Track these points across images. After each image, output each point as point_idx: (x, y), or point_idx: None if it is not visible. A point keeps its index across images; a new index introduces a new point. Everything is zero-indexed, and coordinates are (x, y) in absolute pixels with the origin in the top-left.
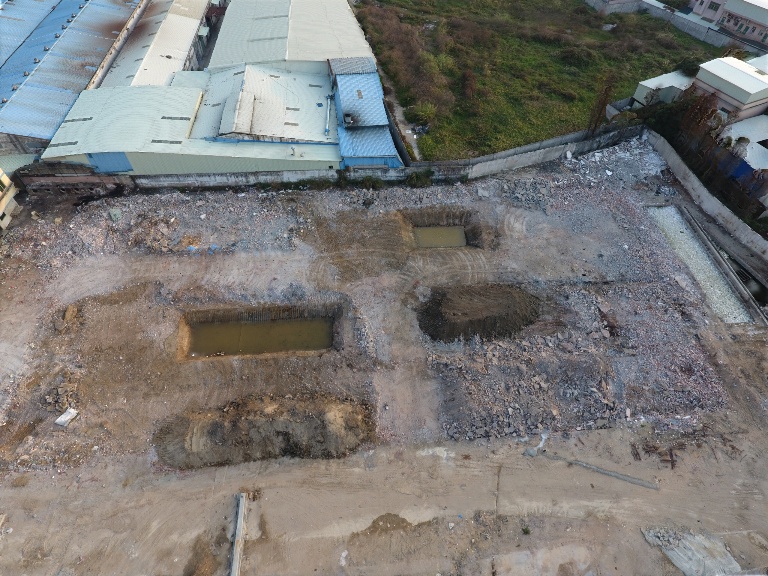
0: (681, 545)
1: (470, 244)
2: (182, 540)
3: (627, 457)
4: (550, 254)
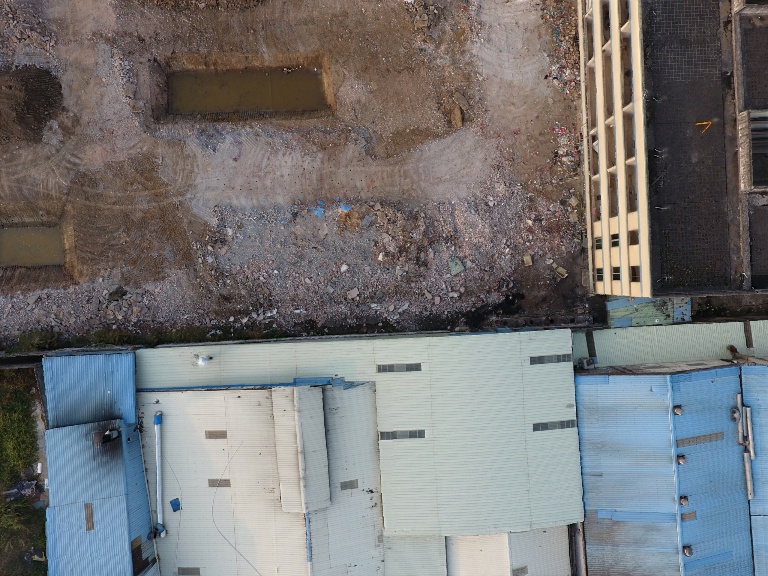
0: None
1: None
2: None
3: None
4: None
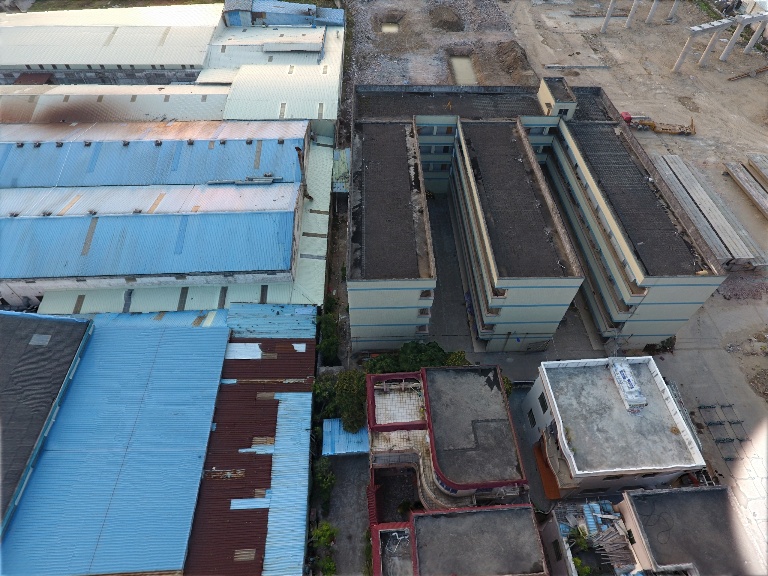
0: (535, 2)
1: (397, 21)
2: (565, 78)
3: (508, 4)
4: (409, 1)
